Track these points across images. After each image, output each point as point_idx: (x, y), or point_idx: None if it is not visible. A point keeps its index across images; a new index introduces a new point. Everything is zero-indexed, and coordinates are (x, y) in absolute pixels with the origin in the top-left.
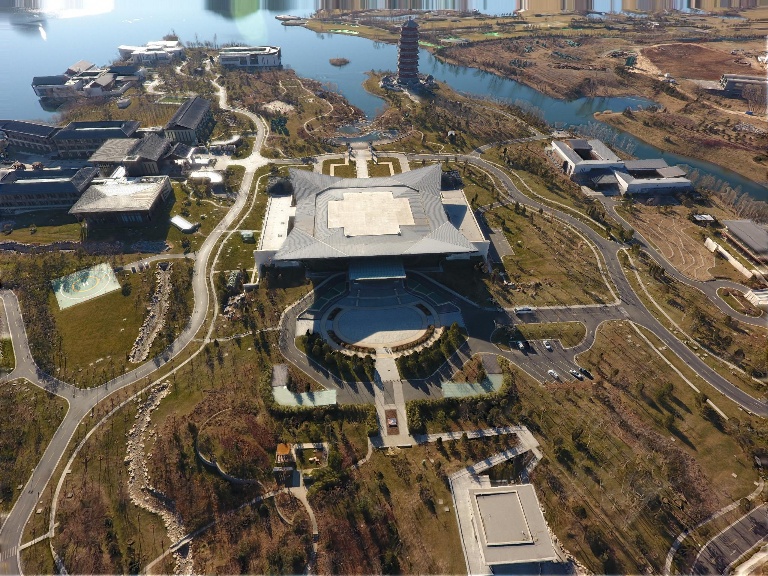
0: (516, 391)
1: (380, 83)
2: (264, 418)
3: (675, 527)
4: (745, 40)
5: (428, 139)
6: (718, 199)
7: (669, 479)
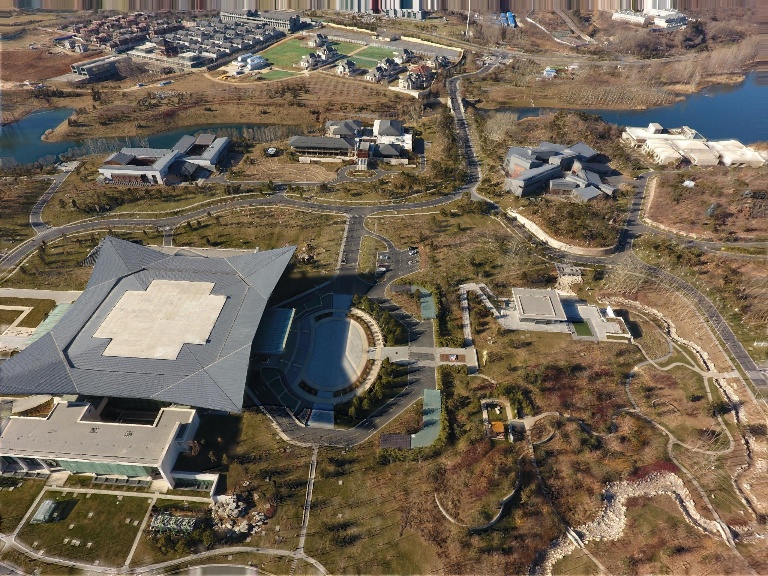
0: None
1: None
2: (450, 457)
3: None
4: (17, 35)
5: None
6: None
7: (497, 241)
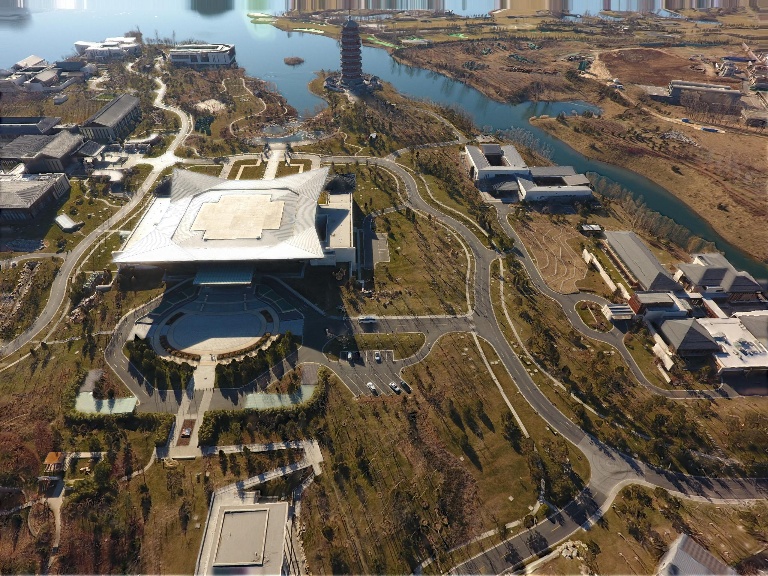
0: (324, 403)
1: (324, 83)
2: (57, 425)
3: (424, 552)
4: (709, 46)
5: (349, 141)
6: (621, 209)
7: (438, 501)
